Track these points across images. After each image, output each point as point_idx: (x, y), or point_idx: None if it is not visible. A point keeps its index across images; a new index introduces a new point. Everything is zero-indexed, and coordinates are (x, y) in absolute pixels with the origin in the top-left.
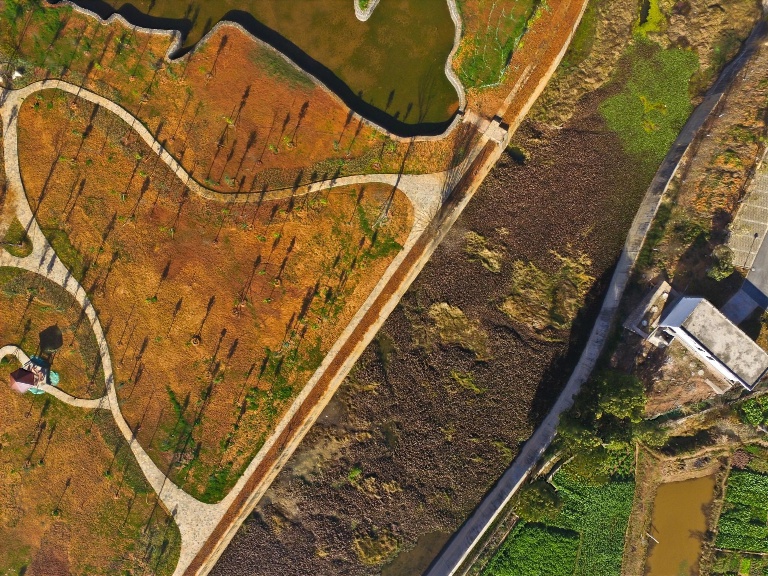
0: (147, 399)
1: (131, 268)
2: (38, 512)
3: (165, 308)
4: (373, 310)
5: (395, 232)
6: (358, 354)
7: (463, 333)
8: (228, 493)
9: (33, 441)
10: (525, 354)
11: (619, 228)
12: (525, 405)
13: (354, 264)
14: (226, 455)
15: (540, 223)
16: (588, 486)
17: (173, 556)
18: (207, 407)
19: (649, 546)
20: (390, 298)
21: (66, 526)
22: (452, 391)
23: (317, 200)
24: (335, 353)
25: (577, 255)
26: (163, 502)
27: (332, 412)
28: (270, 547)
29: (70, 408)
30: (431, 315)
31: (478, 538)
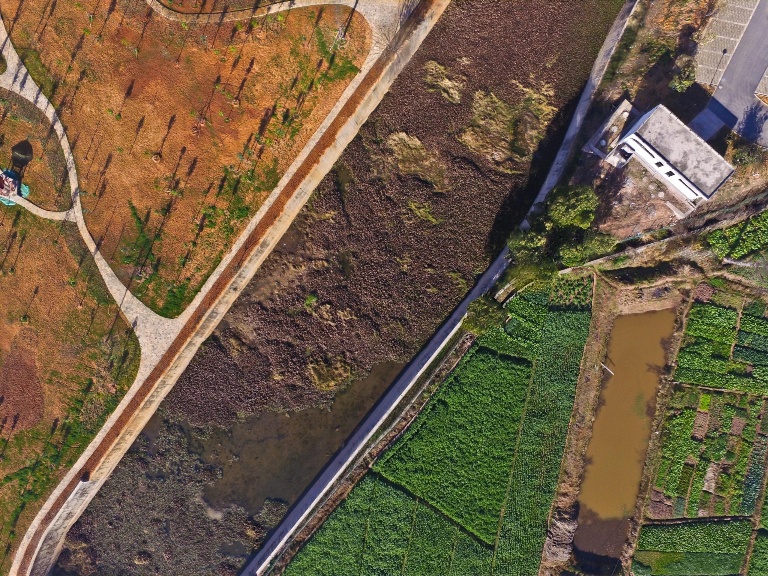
0: (110, 213)
1: (97, 86)
2: (9, 317)
3: (128, 125)
4: (329, 133)
5: (353, 55)
6: (315, 181)
7: (421, 164)
8: (186, 308)
9: (5, 250)
10: (483, 185)
11: (585, 58)
12: (482, 237)
13: (311, 86)
14: (184, 271)
15: (502, 53)
16: (542, 314)
17: (133, 367)
18: (167, 223)
19: (604, 378)
20: (346, 121)
21: (34, 332)
22: (408, 221)
23: (276, 21)
24: (291, 174)
25: (540, 86)
26: (124, 314)
27: (290, 240)
28: (227, 369)
29: (39, 219)
30: (389, 145)
31: (428, 362)
